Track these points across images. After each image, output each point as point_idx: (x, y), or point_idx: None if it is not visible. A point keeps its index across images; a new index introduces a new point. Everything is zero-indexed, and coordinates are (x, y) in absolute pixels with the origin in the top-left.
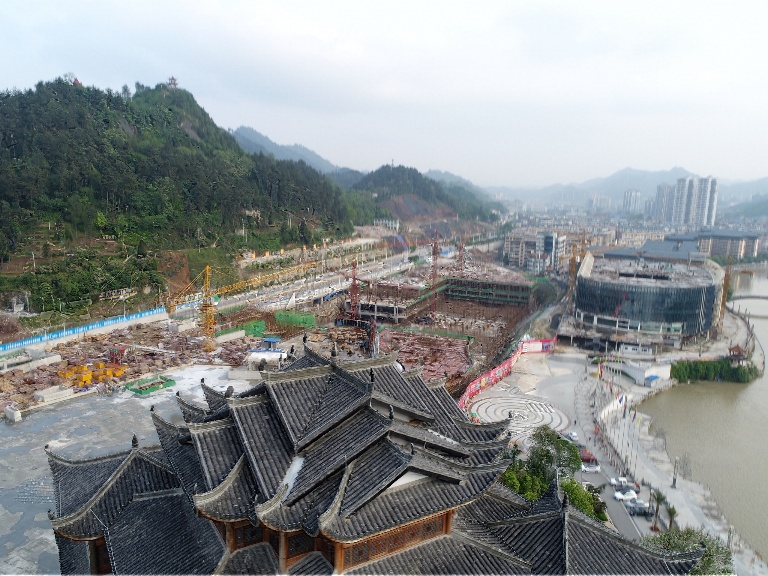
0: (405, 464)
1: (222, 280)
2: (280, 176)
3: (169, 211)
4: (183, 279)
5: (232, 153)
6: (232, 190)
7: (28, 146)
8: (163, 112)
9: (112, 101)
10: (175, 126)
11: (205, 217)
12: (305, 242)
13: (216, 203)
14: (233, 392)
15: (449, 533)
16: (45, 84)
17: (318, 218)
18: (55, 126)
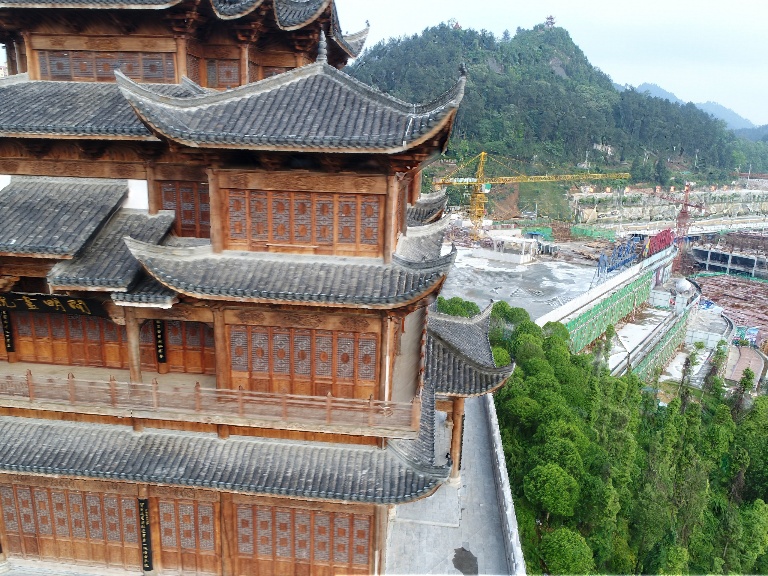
0: None
1: (499, 170)
2: (647, 111)
3: (509, 138)
4: (511, 204)
5: (596, 88)
6: (580, 120)
7: (400, 79)
8: (533, 50)
9: (485, 42)
10: (543, 64)
11: (543, 144)
12: (661, 183)
13: (560, 133)
14: (466, 264)
15: (180, 82)
16: (430, 30)
17: (687, 160)
18: (427, 63)
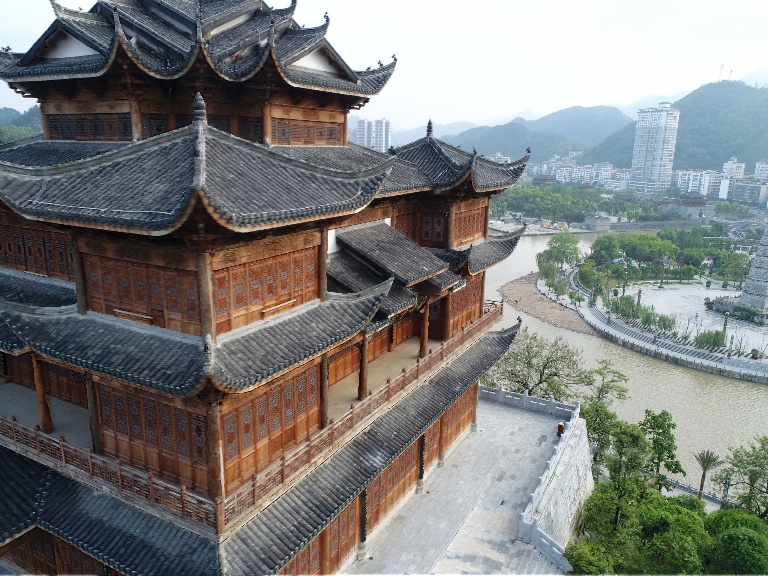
0: (320, 35)
1: None
2: None
3: None
4: None
5: None
6: None
7: None
8: None
9: None
10: None
11: None
12: None
13: None
14: None
15: (346, 144)
16: None
17: None
18: None
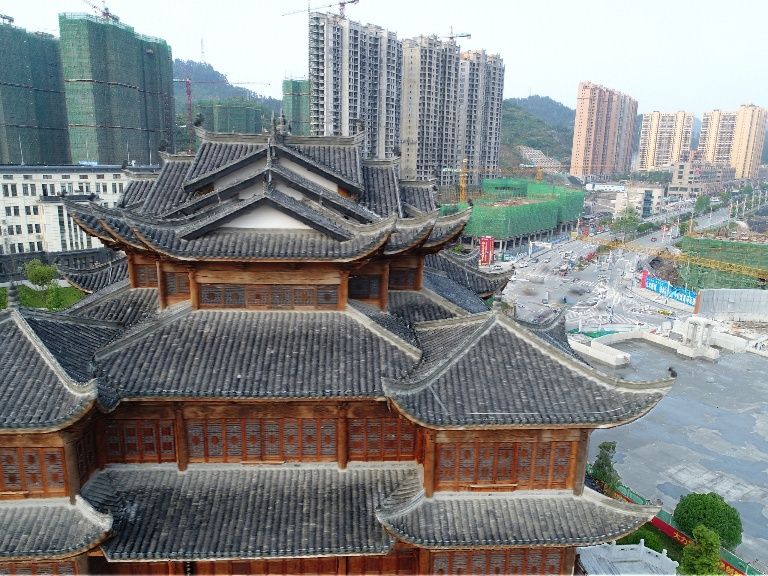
0: None
1: None
2: None
3: None
4: None
5: None
6: None
7: None
8: None
9: None
10: None
11: None
12: None
13: None
14: None
15: None
16: None
17: None
18: None
